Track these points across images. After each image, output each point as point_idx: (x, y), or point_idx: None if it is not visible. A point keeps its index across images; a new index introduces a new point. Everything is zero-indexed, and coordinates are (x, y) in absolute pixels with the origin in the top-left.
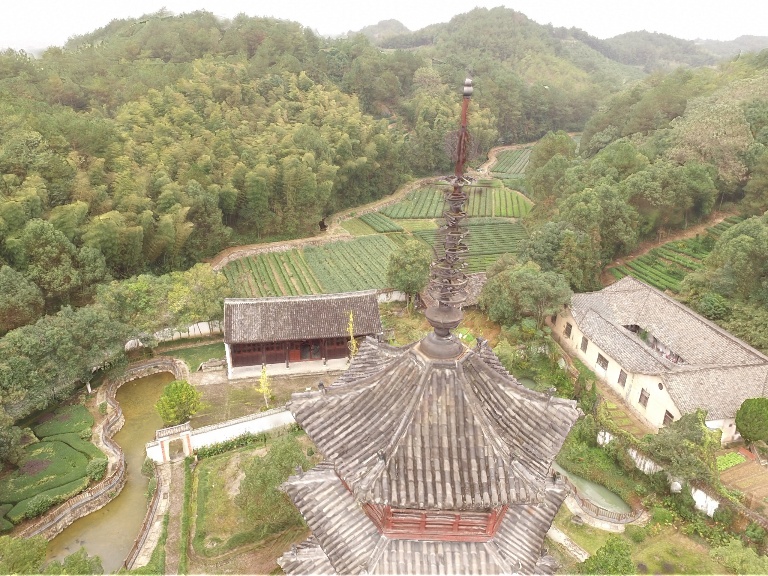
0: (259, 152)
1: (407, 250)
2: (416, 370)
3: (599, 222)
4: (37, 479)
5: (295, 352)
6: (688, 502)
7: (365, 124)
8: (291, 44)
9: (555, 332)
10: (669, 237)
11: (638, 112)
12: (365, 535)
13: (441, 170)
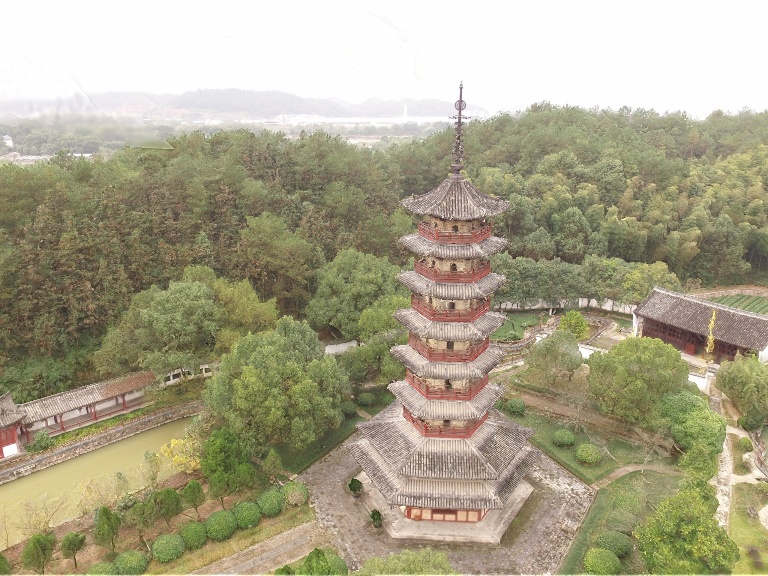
0: None
1: None
2: None
3: None
4: None
5: (691, 346)
6: None
7: None
8: None
9: None
10: None
11: None
12: None
13: None
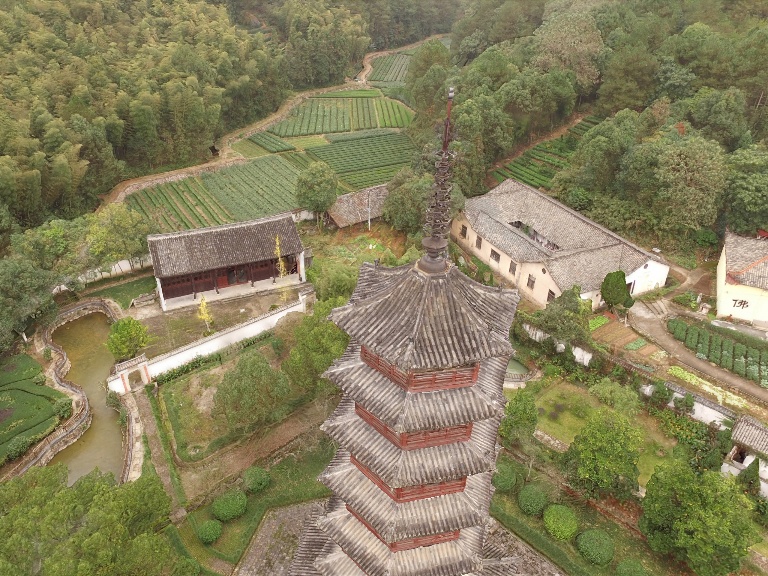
0: (139, 78)
1: (313, 172)
2: (419, 282)
3: (481, 131)
4: (6, 425)
5: (222, 278)
6: (570, 358)
7: (241, 39)
8: None
9: (452, 234)
10: (539, 139)
11: (502, 16)
12: (393, 395)
13: (320, 82)
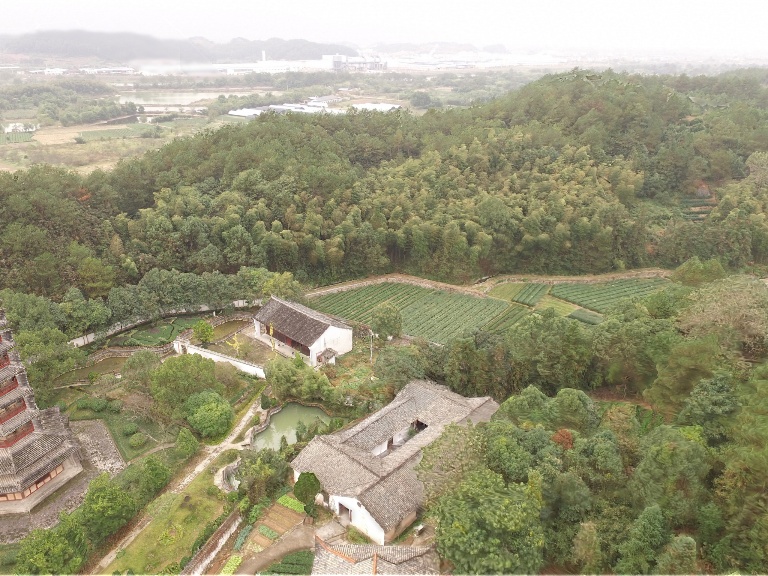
0: (437, 212)
1: None
2: None
3: (525, 346)
4: (148, 335)
5: (289, 340)
6: None
7: (585, 205)
8: (616, 116)
9: None
10: (641, 400)
11: None
12: None
13: None
